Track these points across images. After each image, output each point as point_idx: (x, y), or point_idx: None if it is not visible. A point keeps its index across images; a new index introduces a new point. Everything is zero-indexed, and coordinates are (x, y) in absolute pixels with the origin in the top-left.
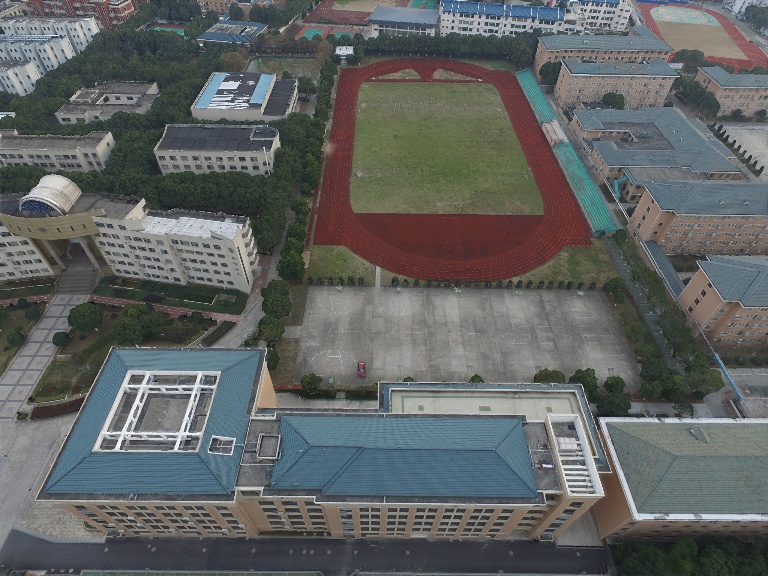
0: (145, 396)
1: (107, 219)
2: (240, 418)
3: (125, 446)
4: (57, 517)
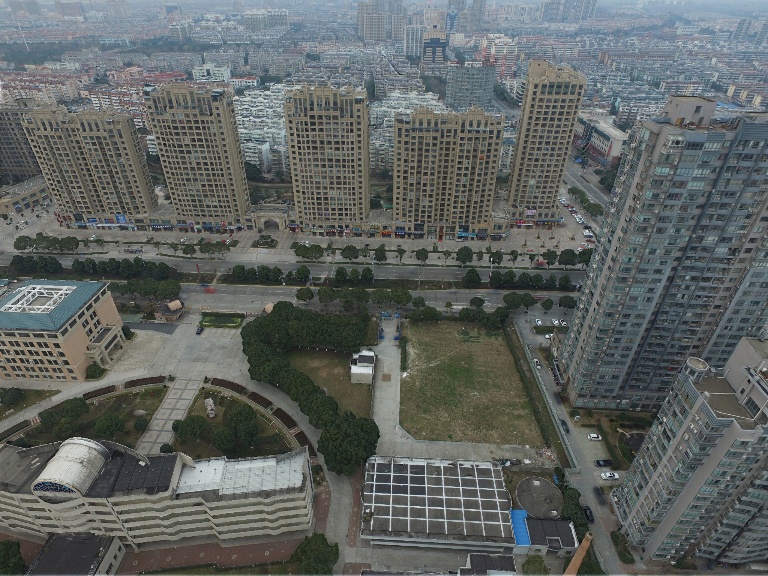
0: (48, 310)
1: (21, 448)
2: (5, 299)
3: (66, 294)
4: (150, 337)
